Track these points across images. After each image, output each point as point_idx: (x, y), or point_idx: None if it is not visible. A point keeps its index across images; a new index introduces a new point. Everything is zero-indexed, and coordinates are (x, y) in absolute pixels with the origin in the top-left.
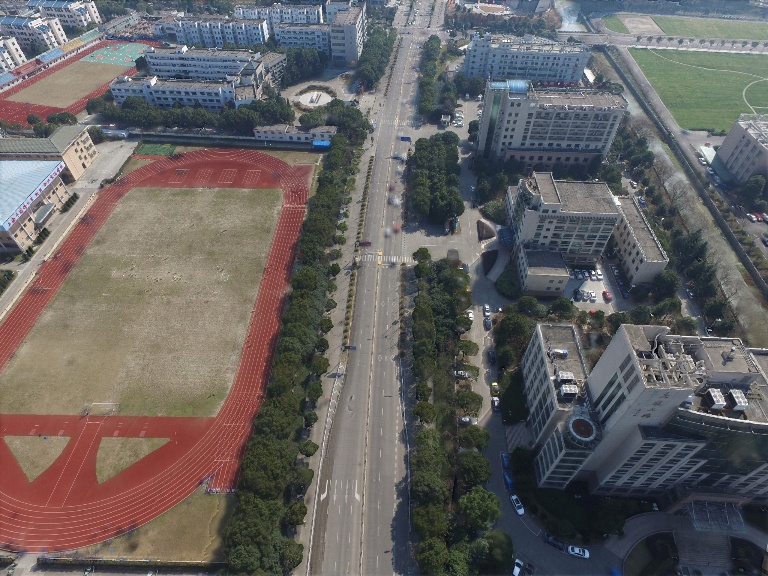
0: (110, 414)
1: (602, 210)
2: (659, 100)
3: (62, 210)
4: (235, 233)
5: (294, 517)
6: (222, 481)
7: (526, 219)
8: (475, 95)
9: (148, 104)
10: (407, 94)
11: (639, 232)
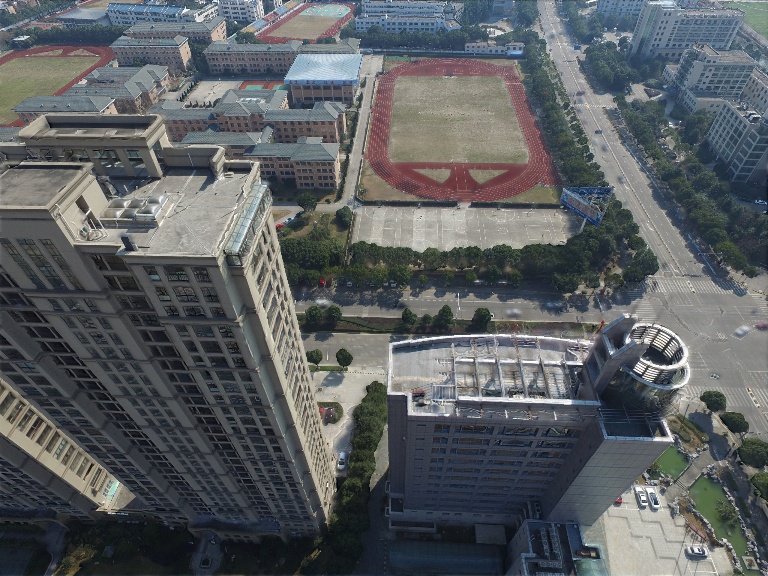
0: (466, 162)
1: (745, 61)
2: (752, 30)
3: (361, 86)
4: (484, 96)
5: (605, 184)
6: (548, 183)
7: (695, 68)
8: (610, 29)
9: (386, 31)
10: (558, 29)
11: (765, 82)
